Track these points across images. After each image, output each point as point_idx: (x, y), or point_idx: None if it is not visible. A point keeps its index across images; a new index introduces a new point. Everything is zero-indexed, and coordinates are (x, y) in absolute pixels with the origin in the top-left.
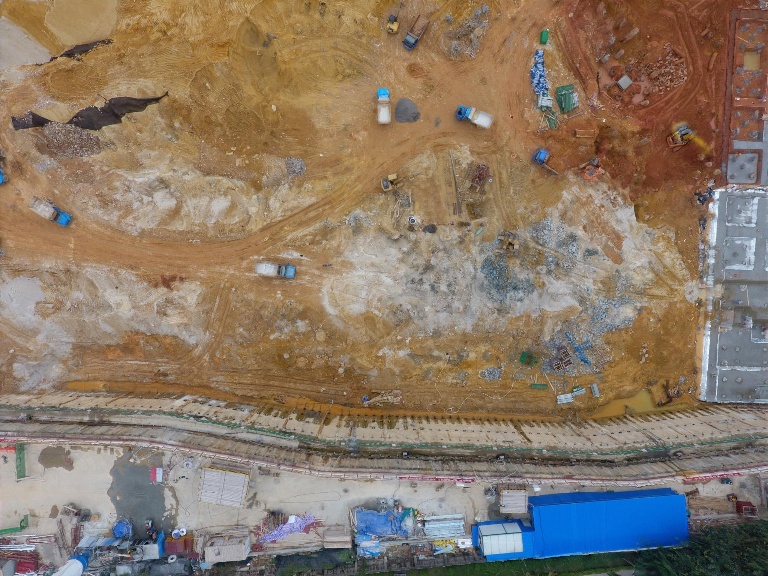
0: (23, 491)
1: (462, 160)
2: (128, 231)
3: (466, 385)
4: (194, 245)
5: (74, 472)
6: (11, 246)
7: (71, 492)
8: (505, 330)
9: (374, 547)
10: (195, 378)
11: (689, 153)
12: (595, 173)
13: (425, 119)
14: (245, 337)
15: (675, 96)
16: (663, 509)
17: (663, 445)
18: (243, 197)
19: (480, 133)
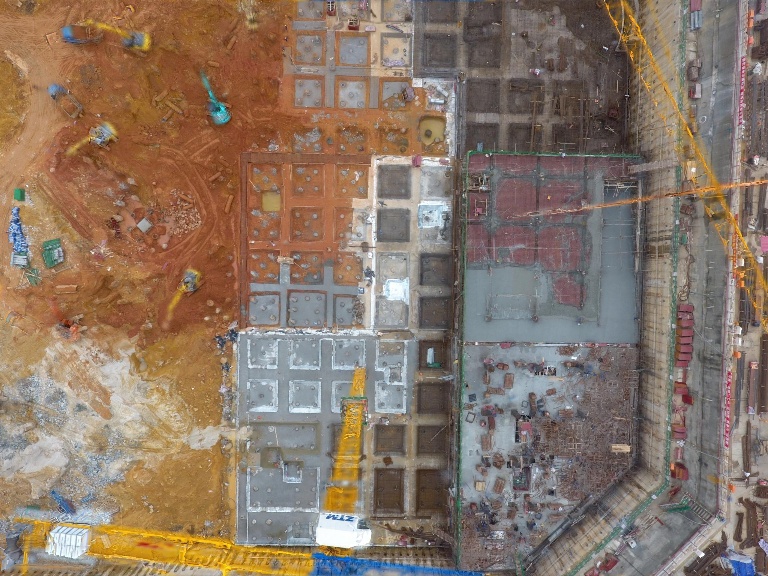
0: None
1: None
2: None
3: None
4: None
5: None
6: None
7: None
8: None
9: None
10: None
11: (202, 298)
12: (66, 333)
13: None
14: None
15: (192, 239)
16: None
17: None
18: None
19: None
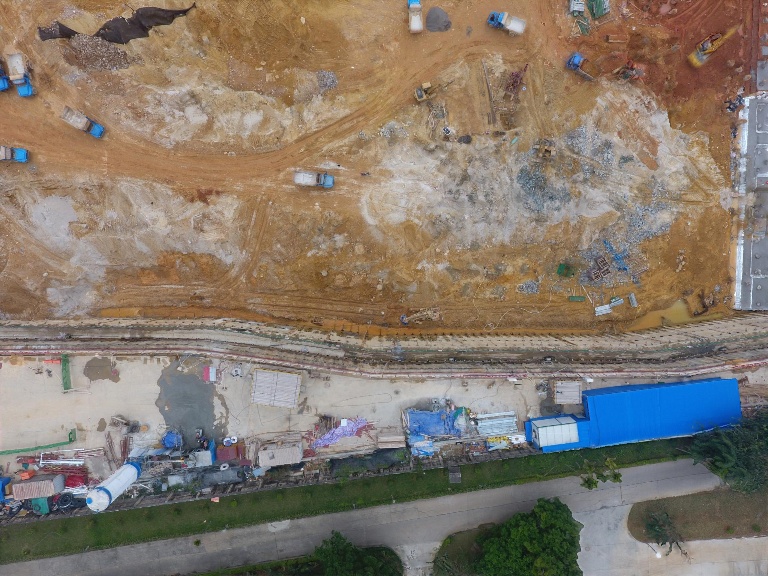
0: (69, 405)
1: (495, 69)
2: (162, 144)
3: (504, 300)
4: (229, 158)
5: (121, 383)
6: (43, 161)
7: (118, 404)
8: (543, 240)
9: (428, 447)
10: (232, 300)
11: (719, 60)
12: (629, 76)
13: (456, 28)
14: (283, 254)
15: (703, 4)
16: (716, 394)
17: (708, 341)
18: (275, 111)
19: (512, 41)
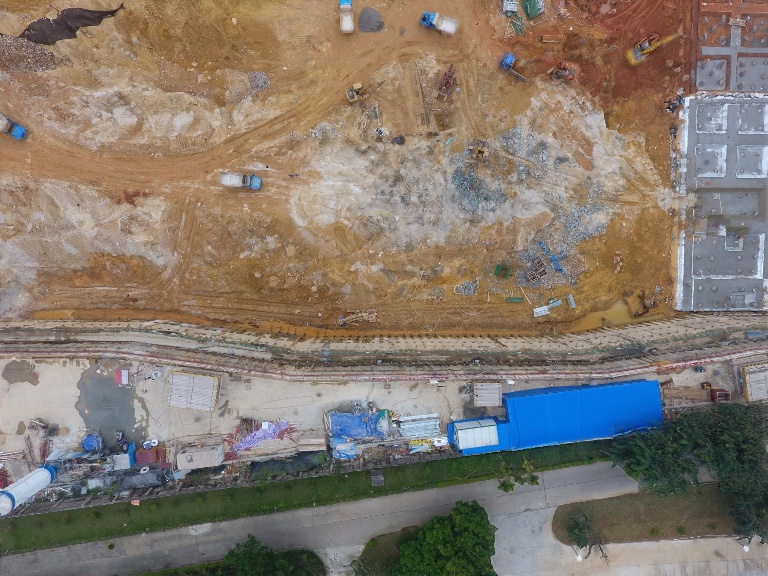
0: None
1: (428, 69)
2: (87, 145)
3: (442, 302)
4: (156, 159)
5: (40, 386)
6: None
7: (38, 407)
8: (478, 241)
9: (350, 449)
10: (166, 302)
11: (657, 60)
12: (562, 77)
13: (389, 28)
14: (214, 256)
15: (642, 4)
16: (637, 396)
17: (638, 343)
18: (206, 112)
19: (445, 41)
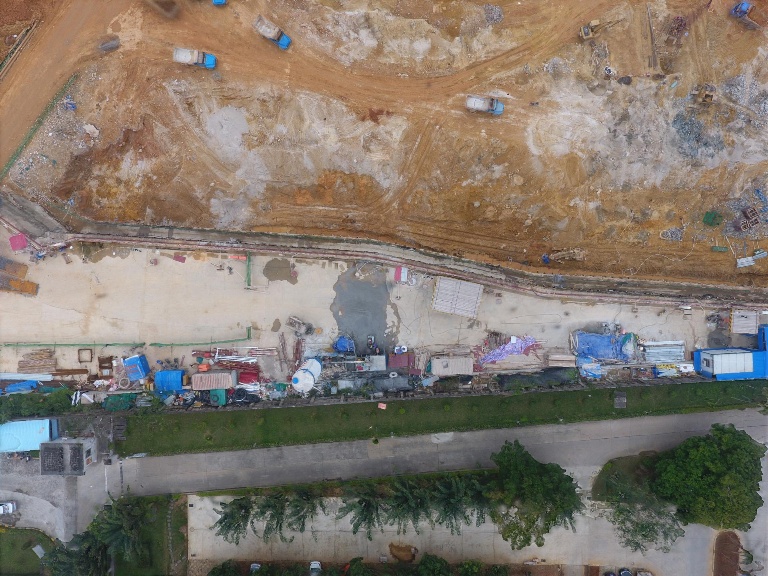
0: (247, 303)
1: (659, 13)
2: (341, 60)
3: (646, 246)
4: (402, 80)
5: (298, 286)
6: (227, 70)
7: (294, 306)
8: (696, 185)
9: (596, 369)
10: (382, 226)
11: None
12: None
13: None
14: (440, 181)
15: None
16: None
17: None
18: (444, 40)
19: None
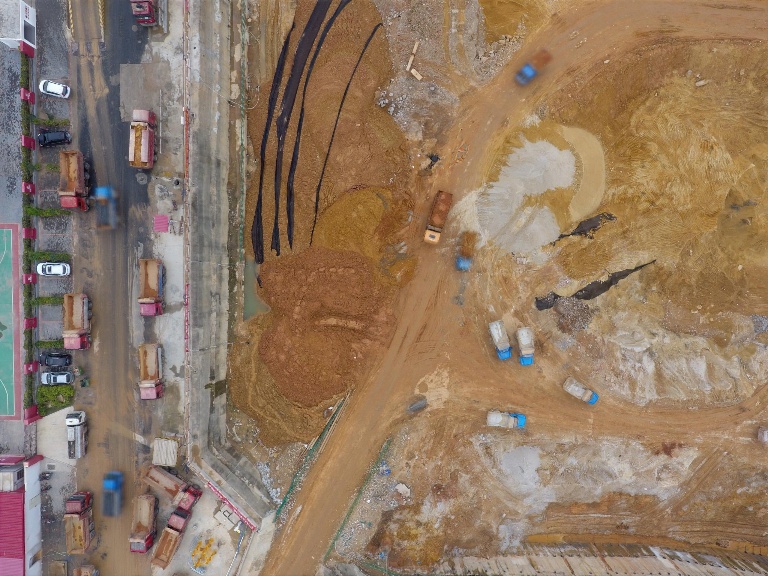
0: None
1: None
2: (638, 403)
3: None
4: (692, 412)
5: None
6: (532, 422)
7: None
8: None
9: None
10: (654, 529)
11: None
12: None
13: None
14: None
15: None
16: None
17: None
18: (719, 358)
19: None
